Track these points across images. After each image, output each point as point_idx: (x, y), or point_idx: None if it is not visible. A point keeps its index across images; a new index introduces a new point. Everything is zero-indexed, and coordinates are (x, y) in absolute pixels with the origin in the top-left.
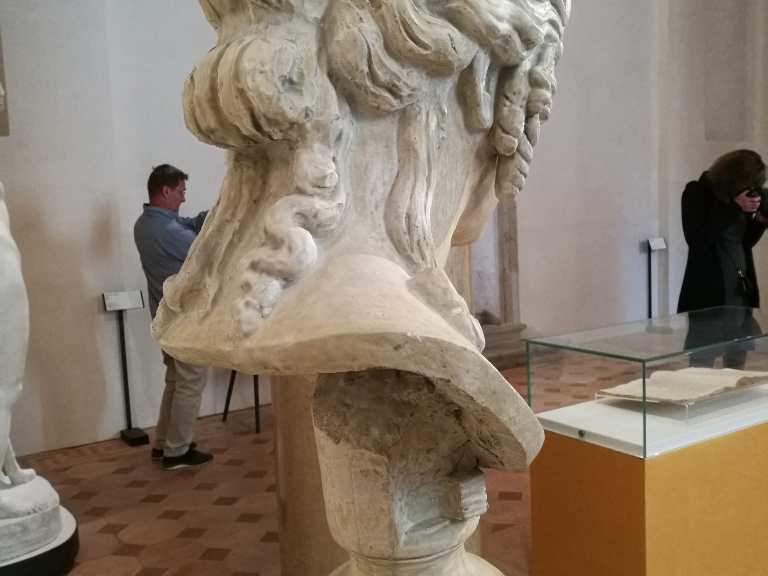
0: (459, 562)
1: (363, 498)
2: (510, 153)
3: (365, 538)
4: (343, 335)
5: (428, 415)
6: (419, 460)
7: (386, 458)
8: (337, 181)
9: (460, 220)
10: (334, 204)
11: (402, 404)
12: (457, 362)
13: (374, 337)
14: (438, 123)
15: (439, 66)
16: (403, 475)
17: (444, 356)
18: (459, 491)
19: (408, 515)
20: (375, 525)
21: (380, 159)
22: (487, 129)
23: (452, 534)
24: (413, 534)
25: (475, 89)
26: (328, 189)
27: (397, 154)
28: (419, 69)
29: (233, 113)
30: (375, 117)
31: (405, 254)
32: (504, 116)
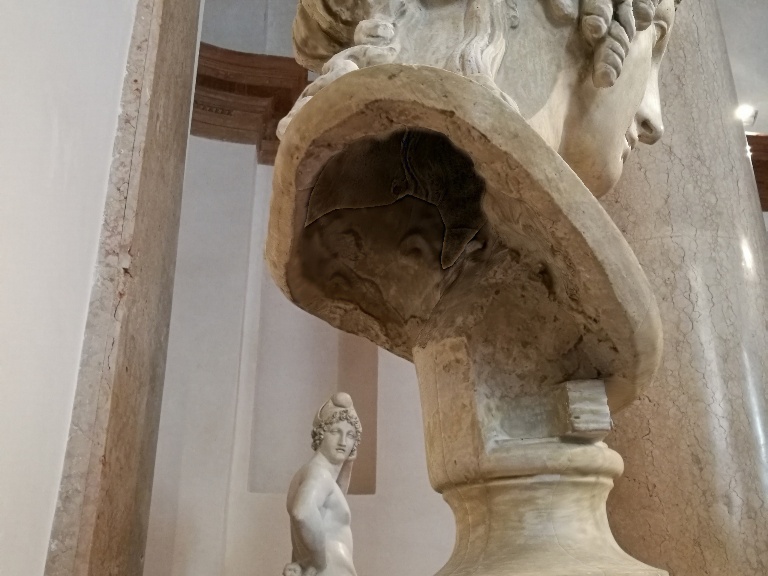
0: (587, 517)
1: (446, 400)
2: (598, 34)
3: (449, 452)
4: (342, 77)
5: (518, 295)
6: (513, 354)
7: (465, 338)
8: (393, 36)
9: (567, 130)
10: (385, 47)
11: (489, 287)
12: (461, 93)
13: (369, 71)
14: (506, 1)
15: None
16: (491, 367)
17: (444, 85)
18: (566, 393)
19: (502, 424)
20: (458, 429)
21: (446, 32)
22: (573, 21)
23: (558, 447)
24: (505, 443)
25: None
26: (382, 40)
27: (464, 28)
28: None
29: (309, 4)
30: (444, 4)
31: None
32: (586, 2)
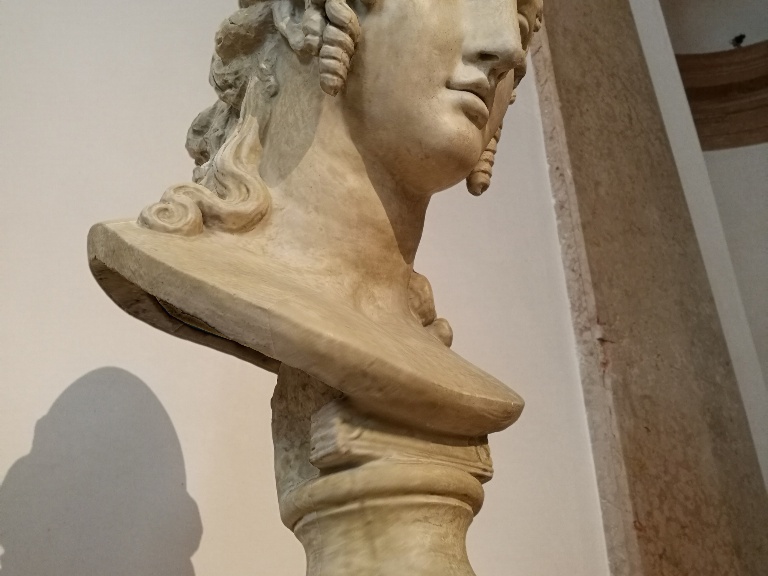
0: (360, 548)
1: None
2: (314, 51)
3: None
4: None
5: None
6: (300, 400)
7: None
8: None
9: (360, 141)
10: None
11: None
12: None
13: None
14: (261, 80)
15: (238, 43)
16: (288, 420)
17: None
18: None
19: (300, 472)
20: None
21: None
22: None
23: (304, 485)
24: None
25: (279, 31)
26: (201, 180)
27: None
28: (238, 57)
29: None
30: None
31: (217, 193)
32: None
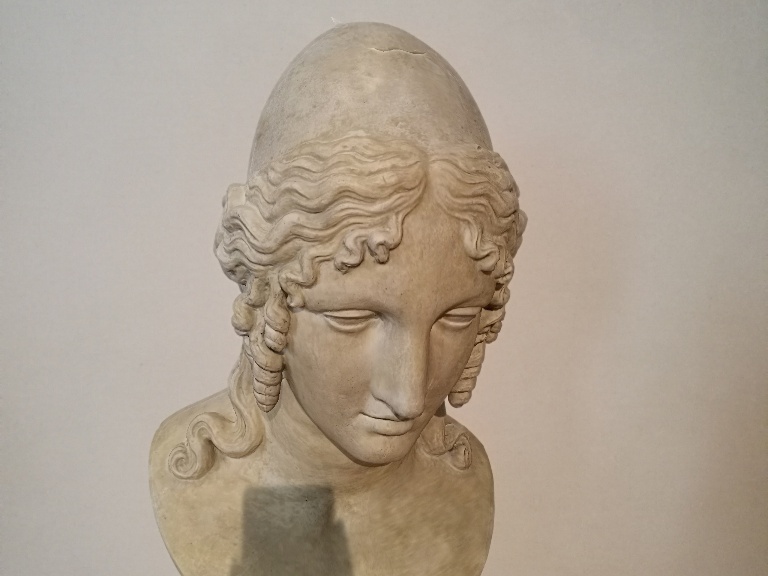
0: None
1: None
2: None
3: None
4: None
5: None
6: None
7: None
8: None
9: None
10: None
11: None
12: None
13: None
14: None
15: None
16: None
17: None
18: None
19: None
20: None
21: None
22: None
23: None
24: None
25: None
26: None
27: None
28: None
29: None
30: None
31: None
32: None
